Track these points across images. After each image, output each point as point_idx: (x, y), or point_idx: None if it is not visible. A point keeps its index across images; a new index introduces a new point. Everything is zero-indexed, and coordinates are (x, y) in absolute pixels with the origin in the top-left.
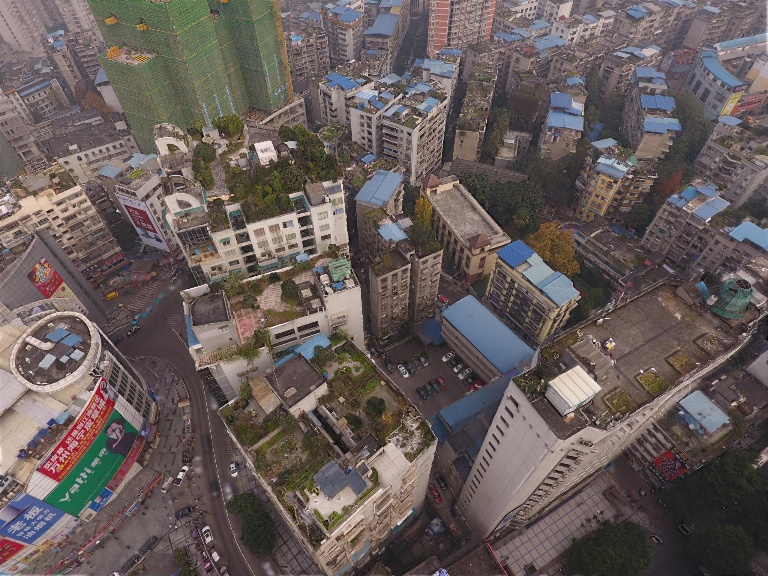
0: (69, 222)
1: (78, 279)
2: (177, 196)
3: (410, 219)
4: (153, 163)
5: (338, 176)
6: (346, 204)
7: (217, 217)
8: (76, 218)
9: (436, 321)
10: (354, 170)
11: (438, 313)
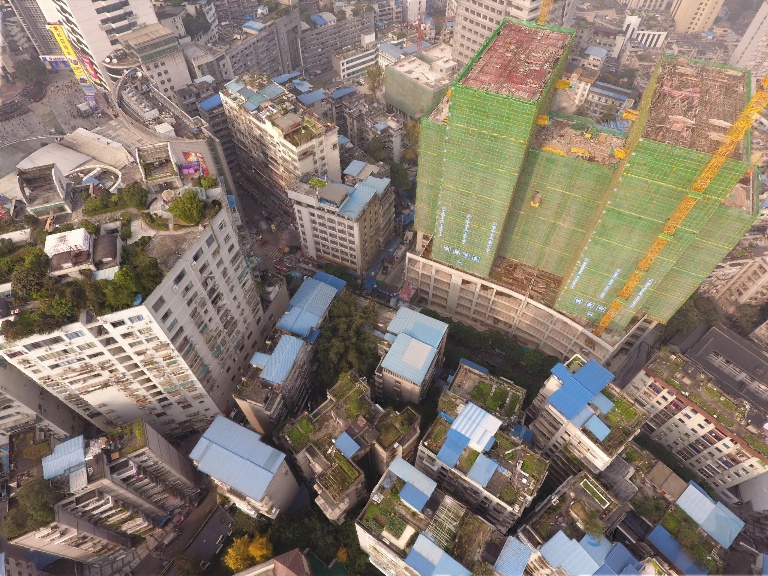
0: (285, 162)
1: (232, 191)
2: (19, 180)
3: (264, 534)
4: (336, 191)
5: (5, 332)
6: (268, 416)
7: (1, 221)
8: (290, 165)
9: (90, 568)
10: (336, 425)
11: (102, 573)
